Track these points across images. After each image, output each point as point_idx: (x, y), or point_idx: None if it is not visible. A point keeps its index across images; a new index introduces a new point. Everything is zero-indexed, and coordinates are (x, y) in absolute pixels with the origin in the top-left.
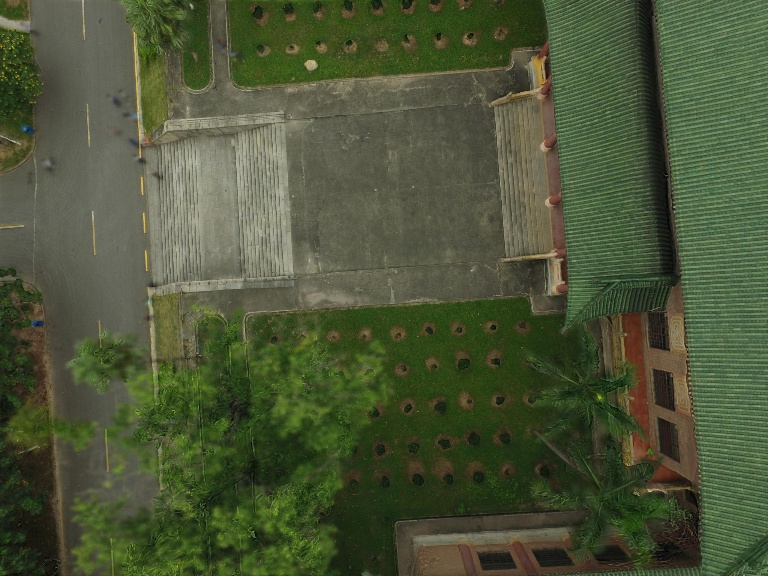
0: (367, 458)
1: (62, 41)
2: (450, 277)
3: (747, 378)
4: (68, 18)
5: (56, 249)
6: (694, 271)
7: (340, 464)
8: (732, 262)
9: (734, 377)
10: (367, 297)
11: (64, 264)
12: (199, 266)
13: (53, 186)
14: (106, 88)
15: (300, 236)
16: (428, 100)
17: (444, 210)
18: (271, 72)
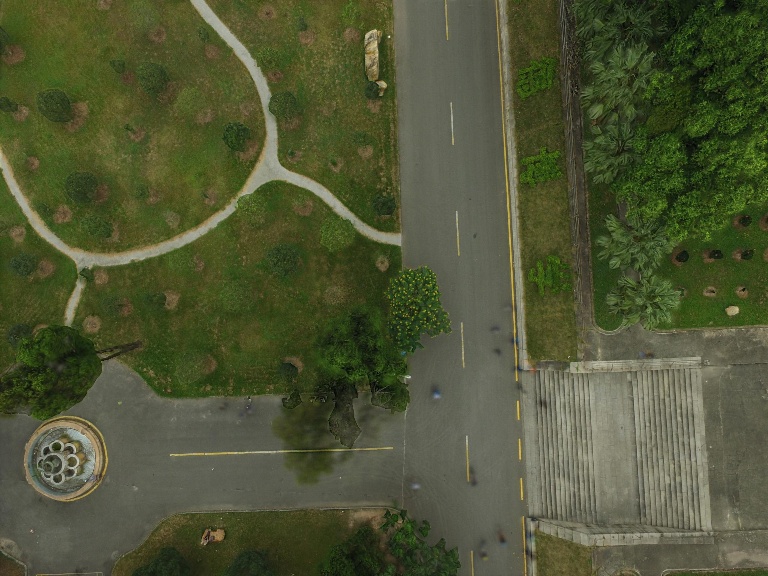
0: None
1: (435, 255)
2: None
3: None
4: (441, 231)
5: (427, 473)
6: None
7: None
8: None
9: None
10: None
11: (435, 489)
12: (593, 506)
13: (424, 407)
14: (482, 307)
15: (718, 489)
16: None
17: None
18: (689, 316)
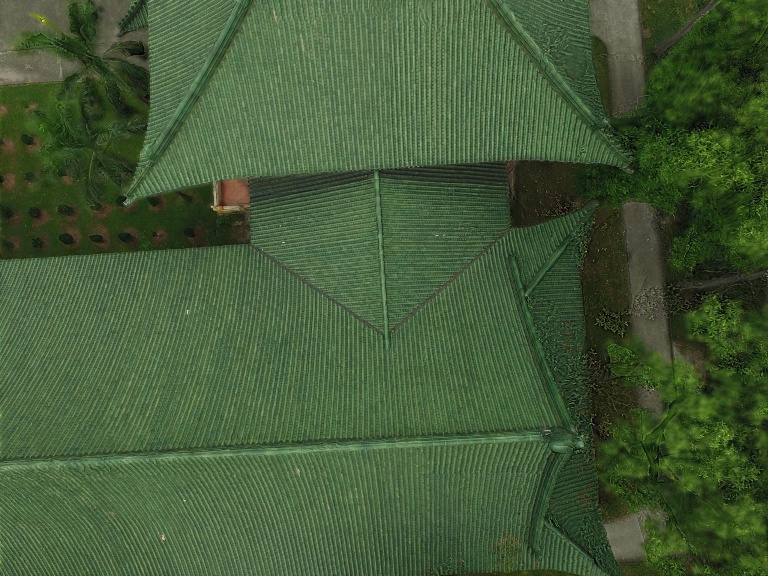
0: (28, 225)
1: None
2: None
3: None
4: None
5: None
6: None
7: (2, 231)
8: None
9: (170, 3)
10: (37, 74)
11: None
12: None
13: None
14: None
15: None
16: None
17: None
18: None
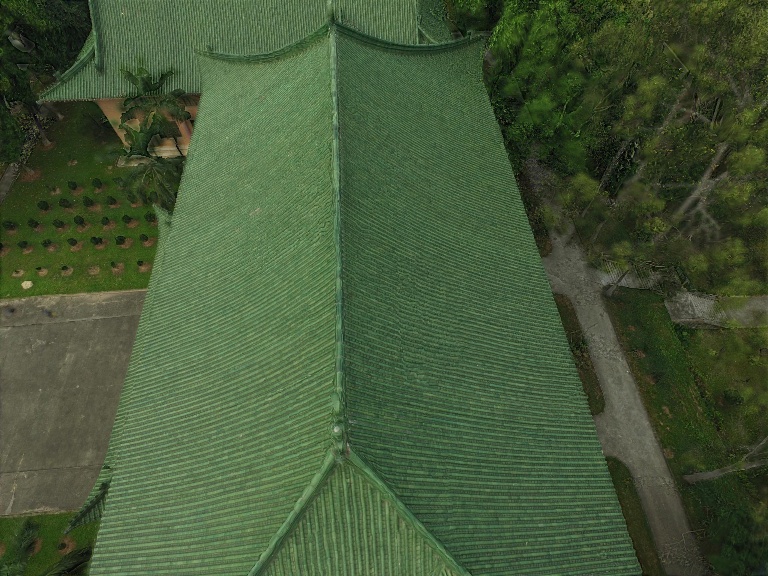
0: None
1: None
2: (81, 481)
3: (125, 571)
4: None
5: None
6: (126, 444)
7: None
8: (151, 431)
9: (117, 571)
10: None
11: None
12: None
13: None
14: None
15: None
16: (119, 311)
17: (100, 409)
18: None
